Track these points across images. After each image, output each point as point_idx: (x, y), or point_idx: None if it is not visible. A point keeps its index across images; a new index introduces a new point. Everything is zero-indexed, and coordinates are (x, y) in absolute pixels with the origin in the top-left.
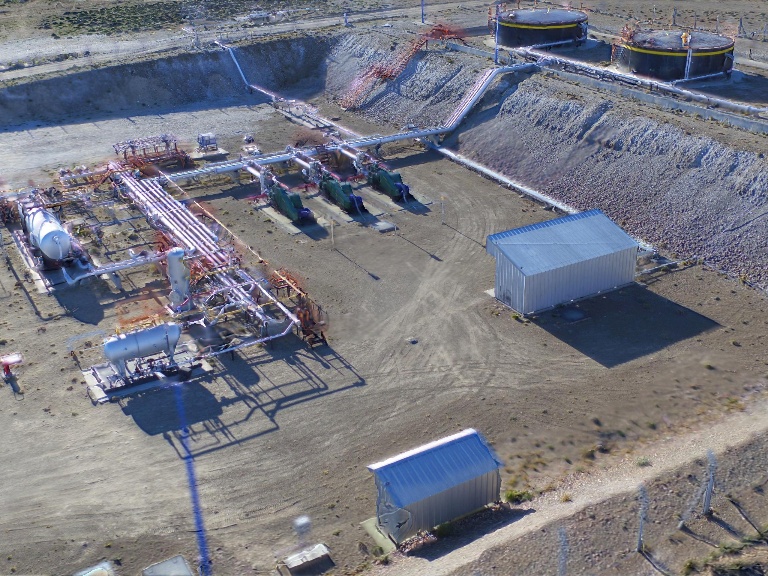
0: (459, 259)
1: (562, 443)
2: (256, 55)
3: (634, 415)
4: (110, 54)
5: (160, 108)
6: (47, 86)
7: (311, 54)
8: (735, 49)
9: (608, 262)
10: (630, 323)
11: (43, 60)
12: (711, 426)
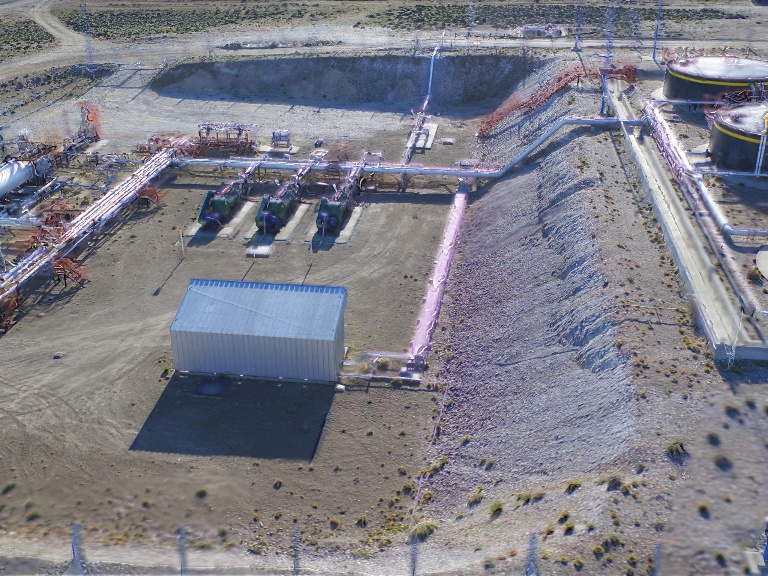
0: None
1: None
2: (458, 66)
3: (45, 499)
4: (349, 46)
5: (334, 102)
6: (257, 66)
7: (513, 74)
8: None
9: (289, 347)
10: (241, 418)
11: (302, 44)
12: (51, 542)
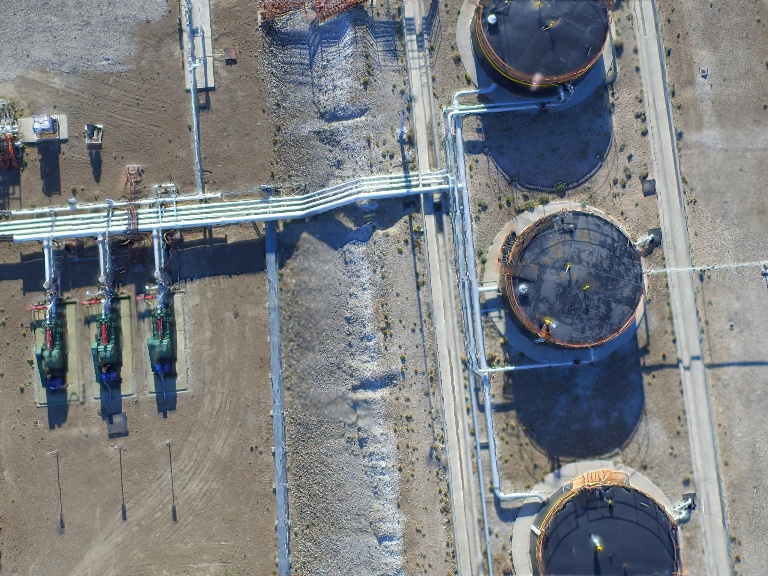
0: (141, 522)
1: None
2: None
3: None
4: None
5: None
6: None
7: None
8: (731, 213)
9: None
10: None
11: None
12: None
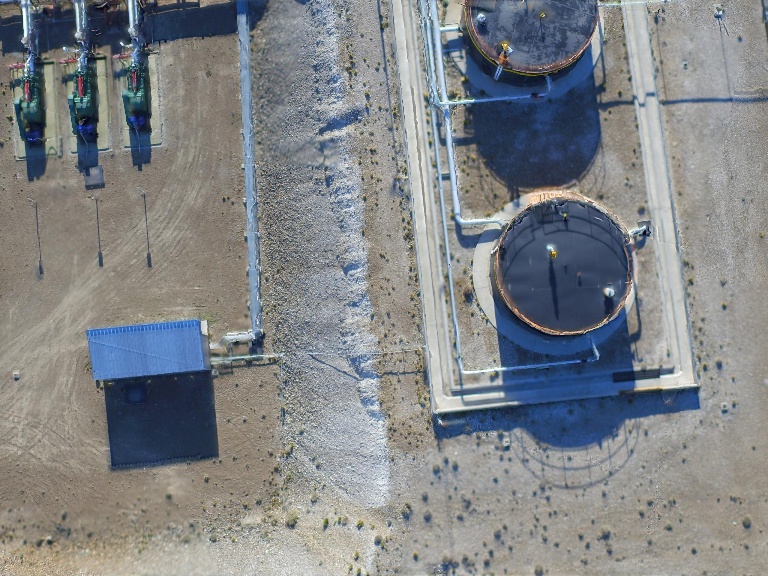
0: (117, 268)
1: (33, 525)
2: None
3: (88, 519)
4: None
5: None
6: None
7: None
8: None
9: None
10: (165, 421)
11: None
12: (112, 557)
